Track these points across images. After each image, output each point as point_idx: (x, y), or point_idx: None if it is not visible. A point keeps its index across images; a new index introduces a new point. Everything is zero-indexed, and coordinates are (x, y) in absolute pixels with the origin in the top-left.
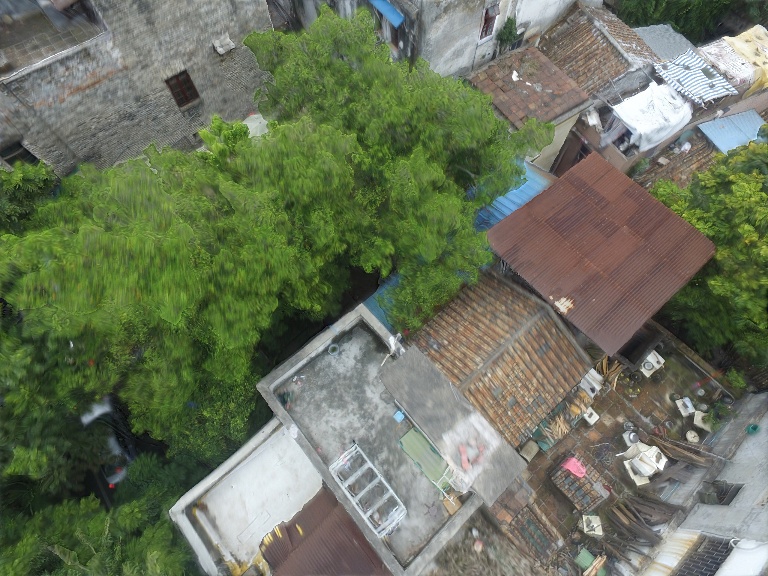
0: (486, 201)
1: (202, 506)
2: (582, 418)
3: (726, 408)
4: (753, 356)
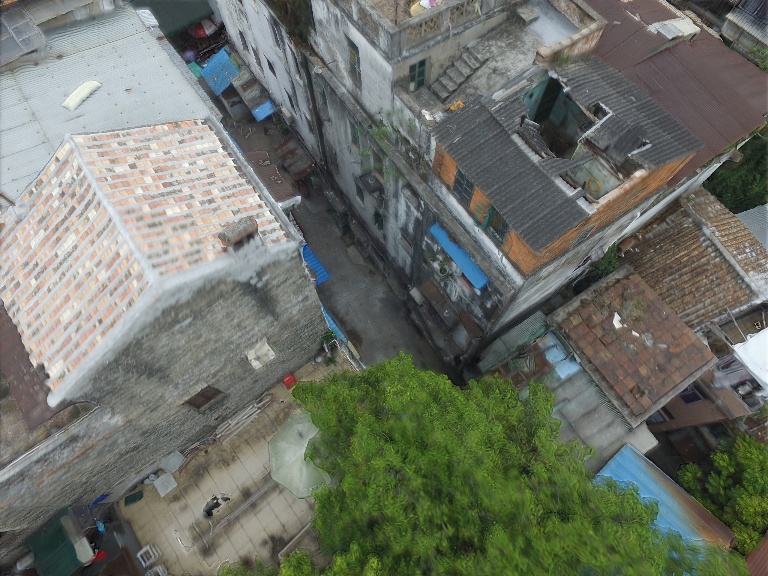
0: None
1: None
2: None
3: None
4: None
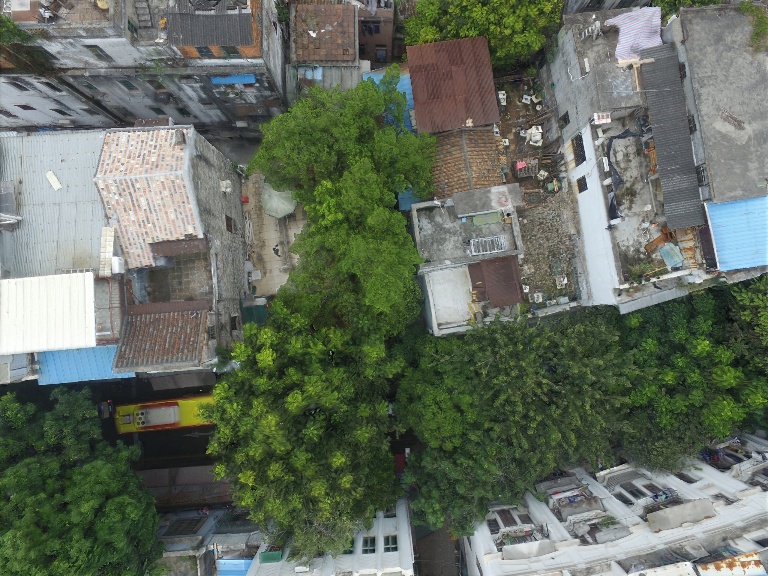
0: (403, 119)
1: (439, 325)
2: (504, 146)
3: (539, 85)
4: (530, 58)
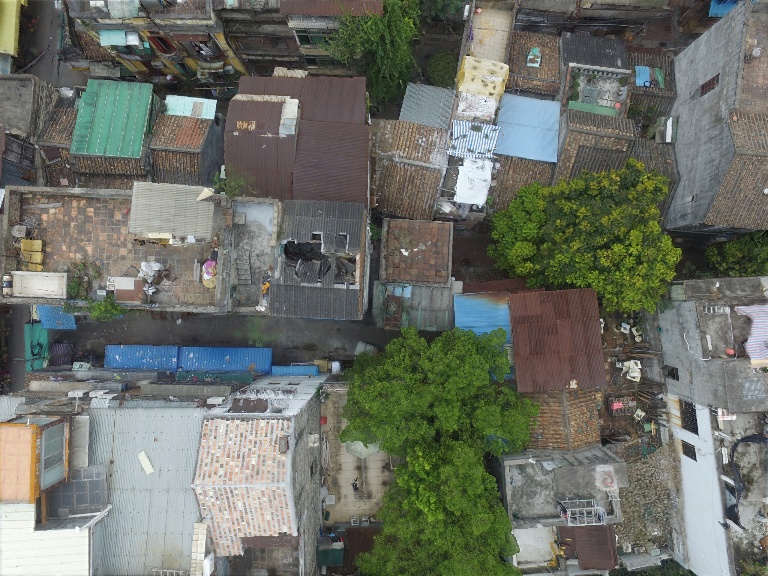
0: None
1: None
2: None
3: (641, 318)
4: None
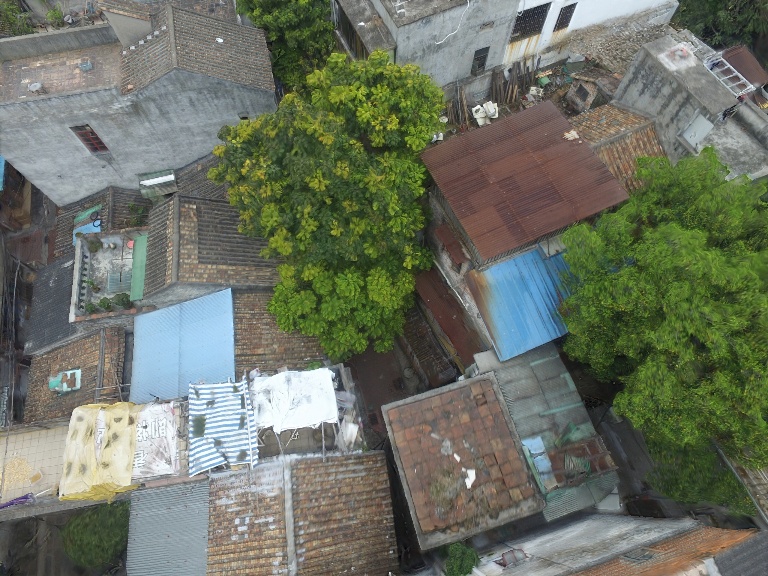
0: None
1: None
2: None
3: None
4: None
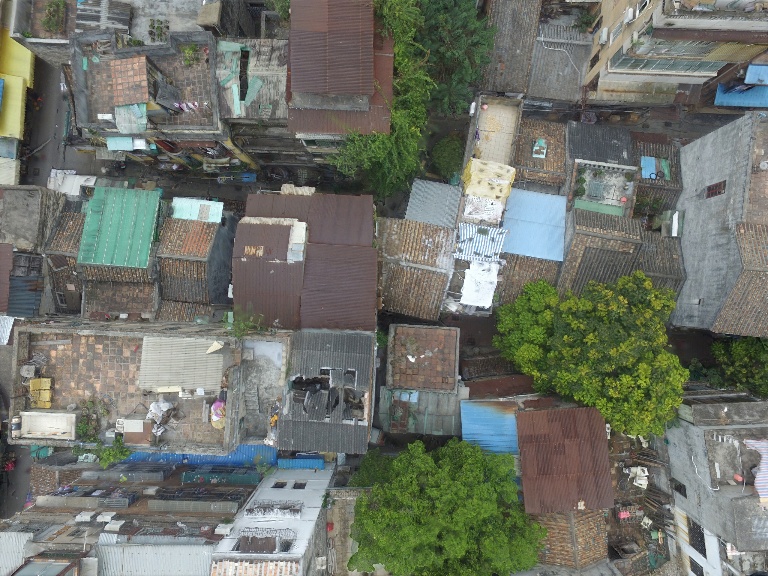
0: None
1: None
2: None
3: None
4: None
